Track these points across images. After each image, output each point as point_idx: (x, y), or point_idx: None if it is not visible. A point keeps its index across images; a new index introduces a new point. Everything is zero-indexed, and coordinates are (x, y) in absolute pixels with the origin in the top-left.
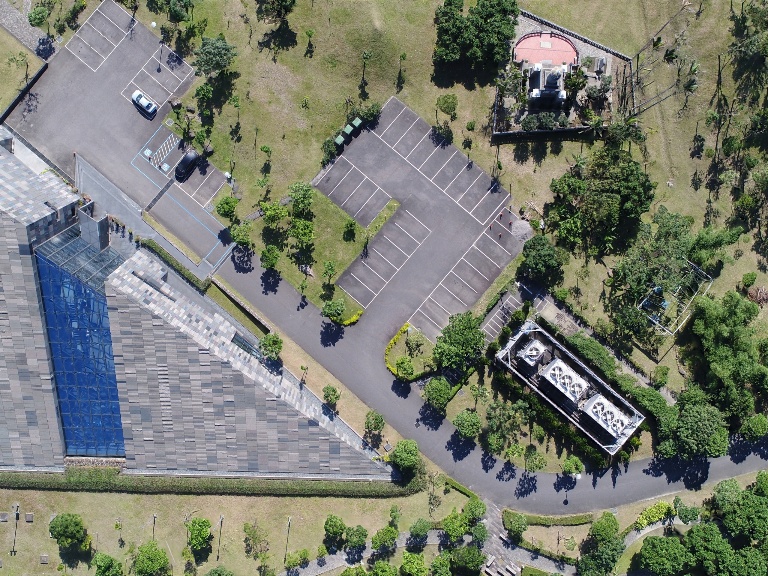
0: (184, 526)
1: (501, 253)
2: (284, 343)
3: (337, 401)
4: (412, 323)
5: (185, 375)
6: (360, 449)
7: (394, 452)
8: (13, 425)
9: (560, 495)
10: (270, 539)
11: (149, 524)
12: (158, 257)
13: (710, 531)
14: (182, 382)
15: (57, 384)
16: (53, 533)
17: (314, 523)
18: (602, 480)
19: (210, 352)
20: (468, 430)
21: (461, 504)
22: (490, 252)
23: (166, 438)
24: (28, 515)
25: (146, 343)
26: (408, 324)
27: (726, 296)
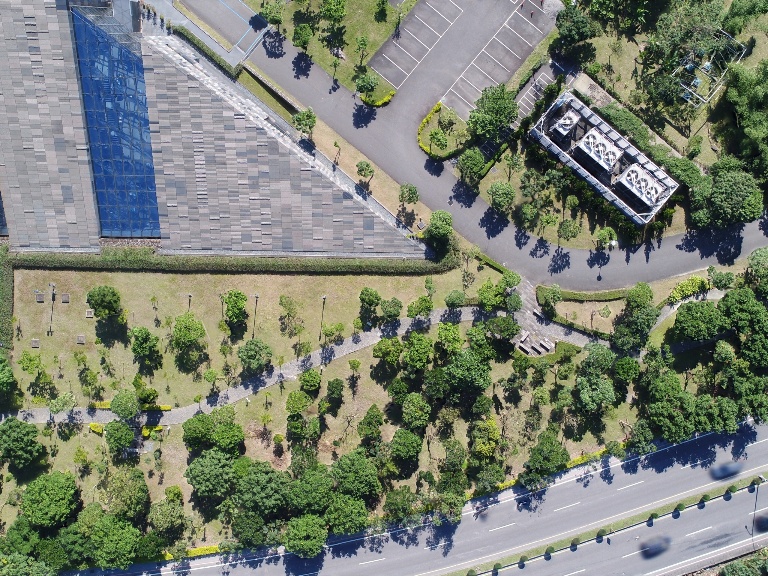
0: (219, 305)
1: (533, 31)
2: (316, 126)
3: (370, 181)
4: (444, 103)
5: (220, 143)
6: (394, 226)
7: (428, 228)
8: (49, 201)
9: (593, 271)
10: (305, 317)
11: (184, 303)
12: (189, 44)
13: (745, 293)
14: (217, 151)
15: (92, 158)
16: (91, 303)
17: (348, 301)
18: (635, 256)
19: (245, 117)
20: (502, 198)
21: (495, 281)
22: (522, 31)
23: (201, 214)
24: (64, 295)
25: (182, 108)
26: (440, 103)
27: (759, 64)
